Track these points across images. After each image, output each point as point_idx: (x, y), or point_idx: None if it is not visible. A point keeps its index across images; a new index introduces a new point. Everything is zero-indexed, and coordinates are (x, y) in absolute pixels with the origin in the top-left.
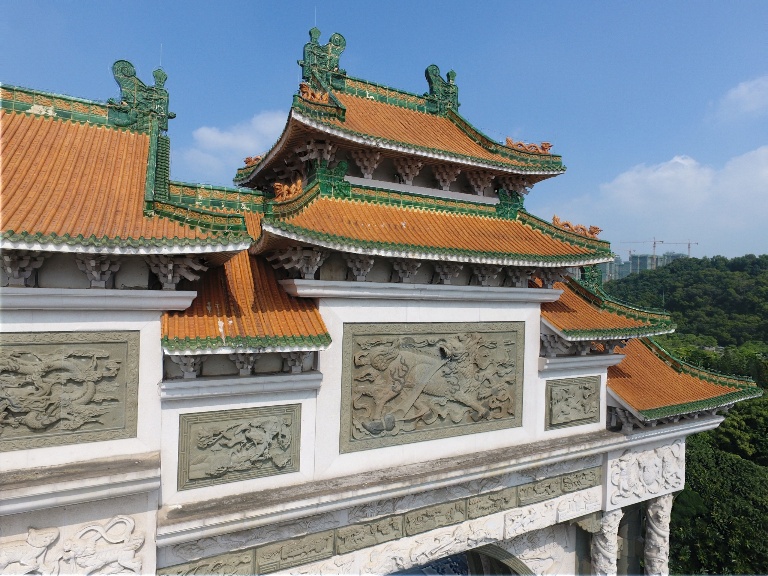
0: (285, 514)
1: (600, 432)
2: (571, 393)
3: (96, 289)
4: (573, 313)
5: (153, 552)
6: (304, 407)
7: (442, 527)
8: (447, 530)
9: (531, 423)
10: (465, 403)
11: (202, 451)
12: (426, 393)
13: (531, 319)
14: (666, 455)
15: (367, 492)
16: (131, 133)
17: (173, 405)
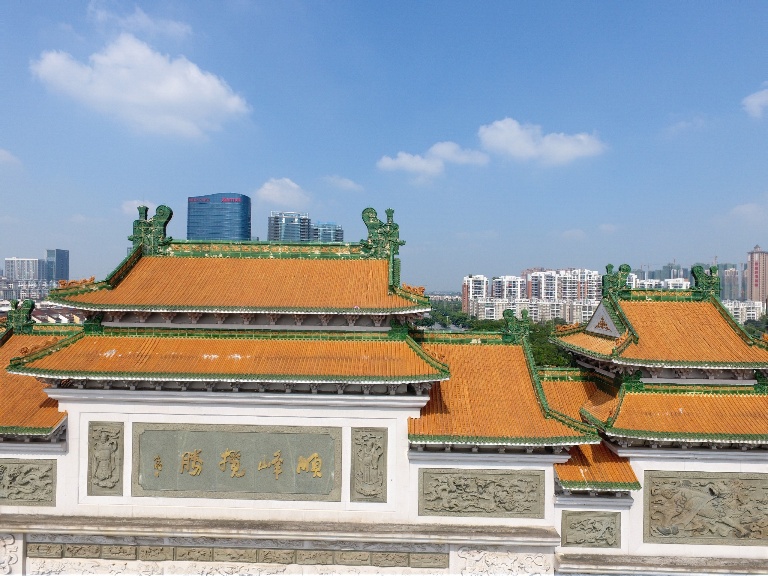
0: (616, 571)
1: None
2: None
3: (531, 455)
4: None
5: (553, 573)
6: (622, 514)
7: None
8: None
9: None
10: (730, 525)
11: (572, 529)
12: (700, 515)
13: None
14: None
15: (663, 570)
16: (513, 346)
17: (559, 506)
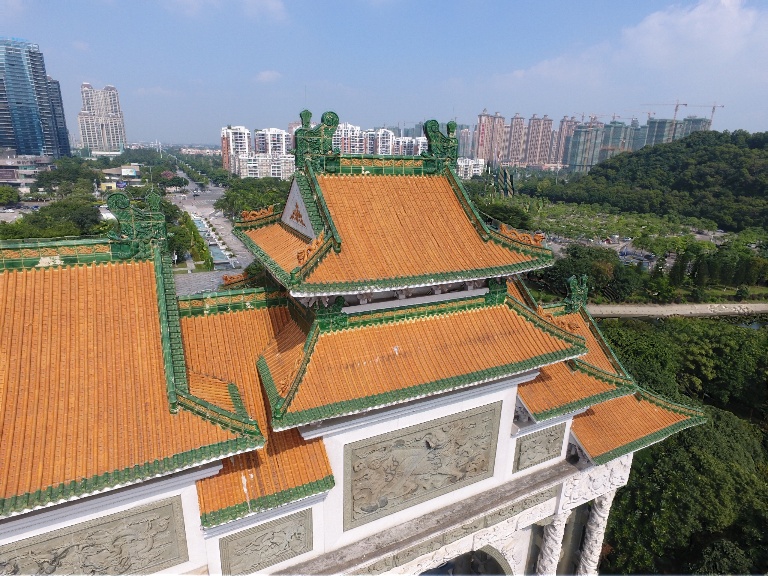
0: None
1: (560, 465)
2: (538, 442)
3: (143, 486)
4: (547, 381)
5: None
6: (314, 509)
7: (424, 554)
8: (428, 556)
9: (501, 472)
10: (446, 474)
11: (238, 556)
12: (413, 474)
13: (508, 397)
14: (615, 465)
15: (365, 564)
16: (136, 263)
17: (213, 535)
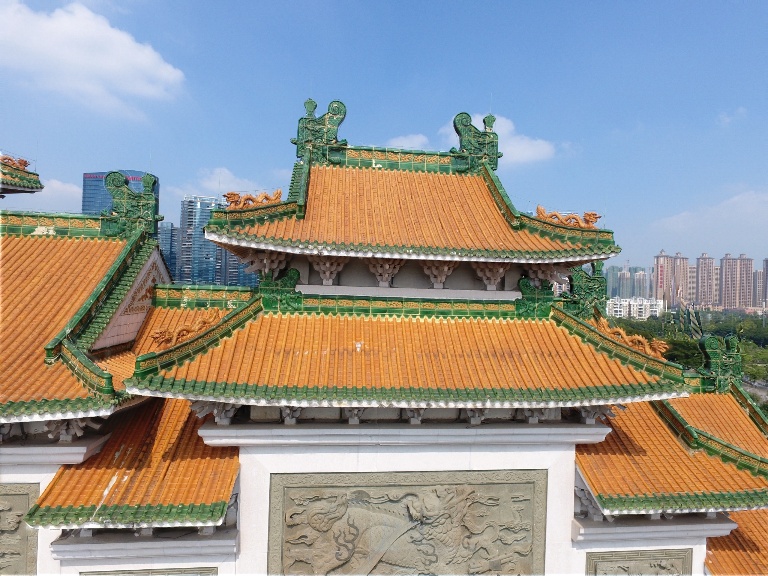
0: None
1: None
2: (634, 572)
3: None
4: (637, 456)
5: None
6: (221, 571)
7: None
8: None
9: None
10: None
11: None
12: (387, 562)
13: (558, 466)
14: None
15: None
16: (120, 242)
17: (73, 562)
